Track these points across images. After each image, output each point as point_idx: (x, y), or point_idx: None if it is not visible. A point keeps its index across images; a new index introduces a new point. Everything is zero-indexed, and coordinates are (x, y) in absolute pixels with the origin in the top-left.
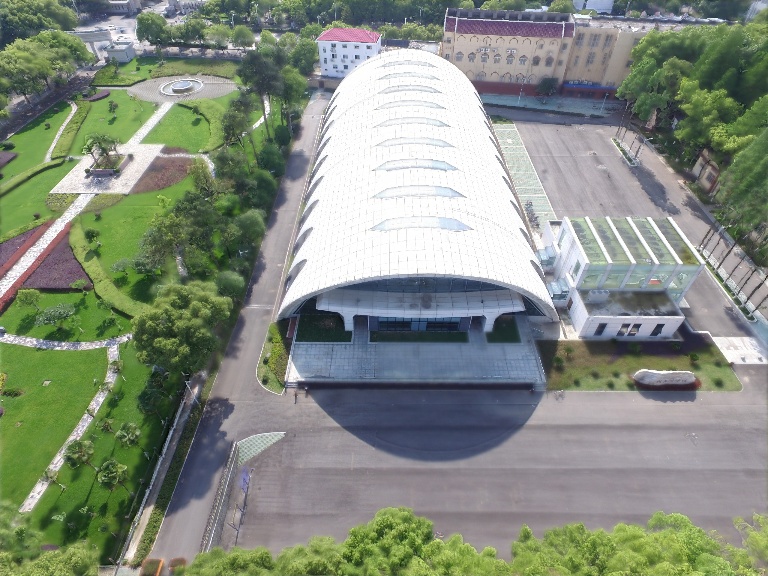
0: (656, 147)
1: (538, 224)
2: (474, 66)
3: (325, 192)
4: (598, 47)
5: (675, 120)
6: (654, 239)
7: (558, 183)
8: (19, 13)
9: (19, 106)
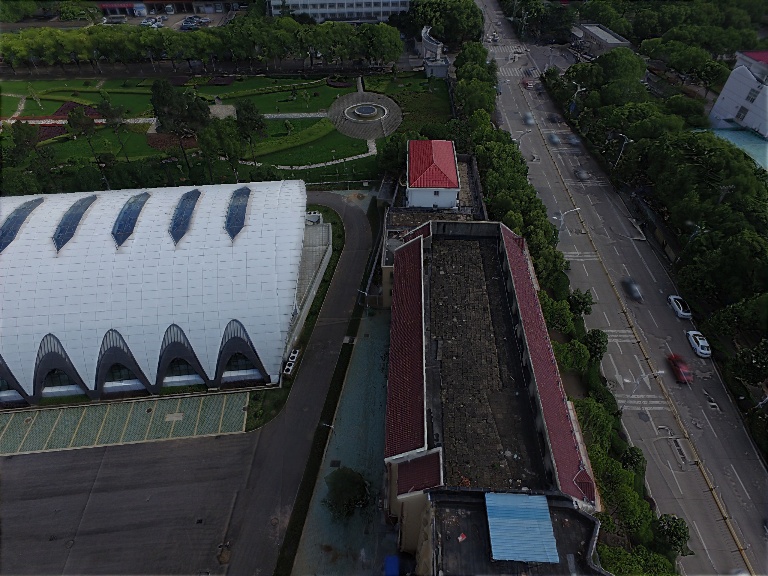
0: None
1: None
2: None
3: None
4: None
5: None
6: None
7: None
8: (427, 7)
9: (314, 65)
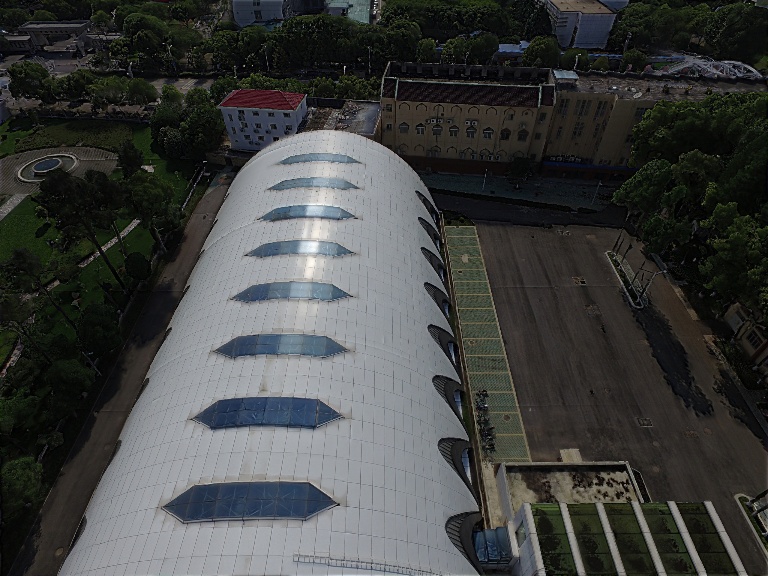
0: (669, 268)
1: (492, 444)
2: (424, 139)
3: (130, 434)
4: (587, 116)
5: (694, 223)
6: (684, 569)
7: (529, 345)
8: None
9: None
